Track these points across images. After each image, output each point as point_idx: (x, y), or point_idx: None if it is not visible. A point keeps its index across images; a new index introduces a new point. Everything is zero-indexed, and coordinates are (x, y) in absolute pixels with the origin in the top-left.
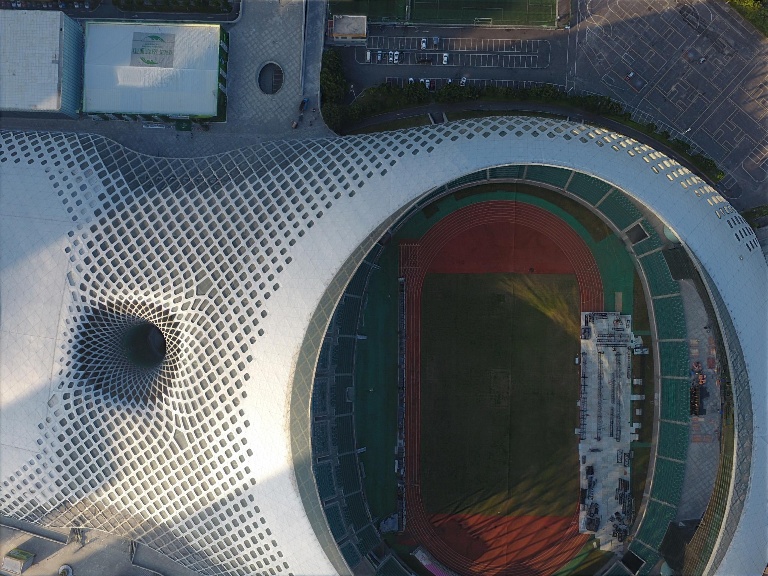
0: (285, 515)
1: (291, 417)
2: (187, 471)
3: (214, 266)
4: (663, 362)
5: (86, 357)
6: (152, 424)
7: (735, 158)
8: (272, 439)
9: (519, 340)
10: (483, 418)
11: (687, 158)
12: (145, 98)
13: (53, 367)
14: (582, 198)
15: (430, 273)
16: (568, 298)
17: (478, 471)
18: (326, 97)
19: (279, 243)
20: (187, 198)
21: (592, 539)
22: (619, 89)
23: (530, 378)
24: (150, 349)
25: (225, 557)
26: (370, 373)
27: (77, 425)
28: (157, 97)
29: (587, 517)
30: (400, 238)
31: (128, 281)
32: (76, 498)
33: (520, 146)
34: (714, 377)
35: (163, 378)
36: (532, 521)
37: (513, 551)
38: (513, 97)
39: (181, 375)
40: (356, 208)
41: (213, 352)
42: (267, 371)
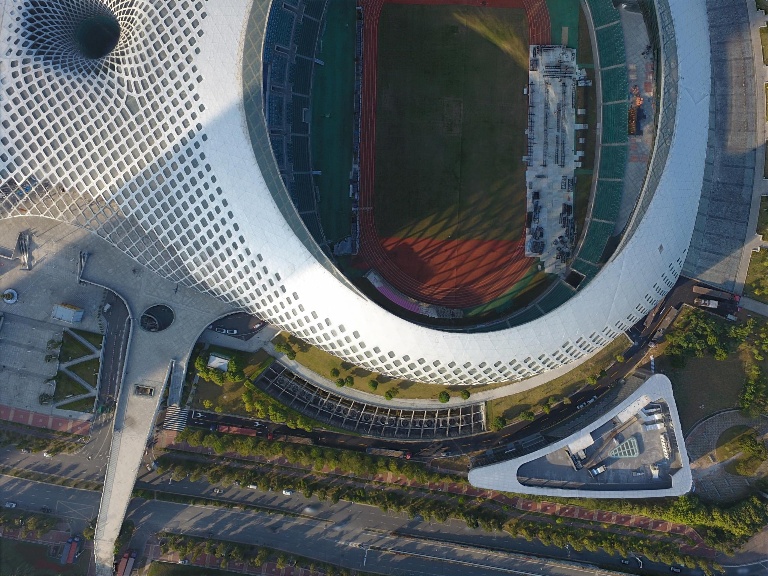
0: (236, 167)
1: (243, 64)
2: (138, 137)
3: None
4: (604, 89)
5: (36, 28)
6: (103, 92)
7: None
8: (224, 89)
9: (471, 70)
10: (436, 145)
11: None
12: None
13: (1, 33)
14: None
15: (387, 3)
16: (518, 31)
17: (430, 196)
18: None
19: None
20: None
21: (537, 262)
22: None
23: (481, 107)
24: None
25: (175, 233)
26: (327, 99)
27: (25, 95)
28: None
29: (533, 241)
30: None
31: None
32: (22, 175)
33: None
34: (650, 100)
35: (116, 52)
36: (481, 244)
37: (462, 274)
38: None
39: (134, 41)
40: None
41: (167, 13)
42: (221, 24)
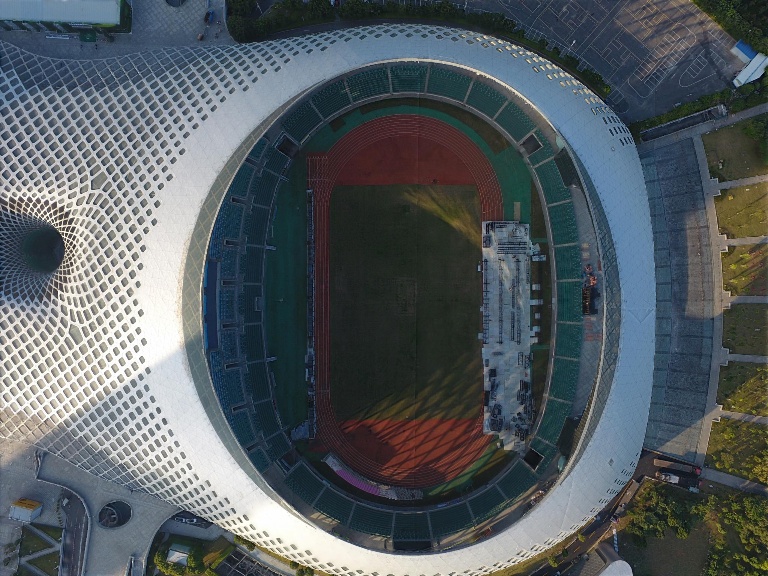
0: (179, 402)
1: (183, 302)
2: (83, 366)
3: (109, 160)
4: (558, 266)
5: None
6: (47, 320)
7: (622, 75)
8: (165, 326)
9: (424, 249)
10: (390, 325)
11: (578, 74)
12: (46, 6)
13: None
14: (481, 111)
15: (337, 185)
16: (470, 208)
17: (386, 377)
18: (231, 10)
19: (173, 136)
20: (83, 96)
21: (496, 439)
22: (514, 9)
23: (435, 286)
24: (56, 262)
25: (125, 455)
26: (280, 284)
27: None
28: (59, 5)
29: (491, 418)
30: (308, 151)
31: (21, 178)
32: None
33: (408, 45)
34: None
35: (59, 276)
36: (439, 424)
37: (421, 454)
38: (414, 14)
39: (76, 270)
40: (249, 101)
41: (107, 244)
42: (160, 259)
